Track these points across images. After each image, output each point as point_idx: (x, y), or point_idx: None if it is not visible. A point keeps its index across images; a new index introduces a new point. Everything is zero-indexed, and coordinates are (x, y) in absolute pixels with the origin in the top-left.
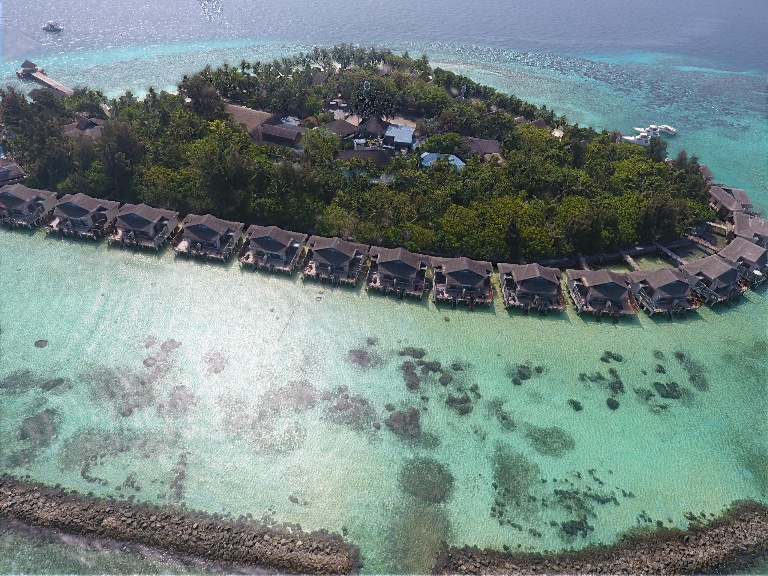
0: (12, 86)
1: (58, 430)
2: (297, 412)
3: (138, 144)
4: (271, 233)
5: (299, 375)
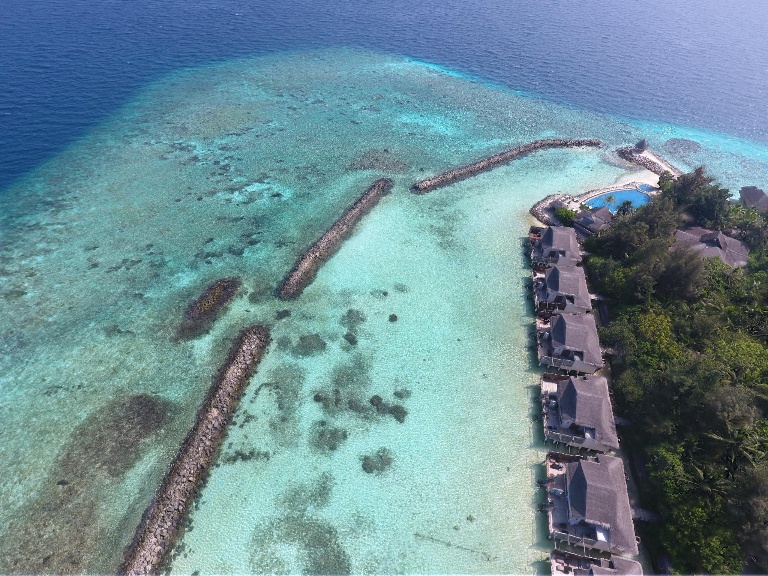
0: (759, 175)
1: (306, 357)
2: (303, 572)
3: (689, 288)
4: (596, 487)
5: (360, 570)
